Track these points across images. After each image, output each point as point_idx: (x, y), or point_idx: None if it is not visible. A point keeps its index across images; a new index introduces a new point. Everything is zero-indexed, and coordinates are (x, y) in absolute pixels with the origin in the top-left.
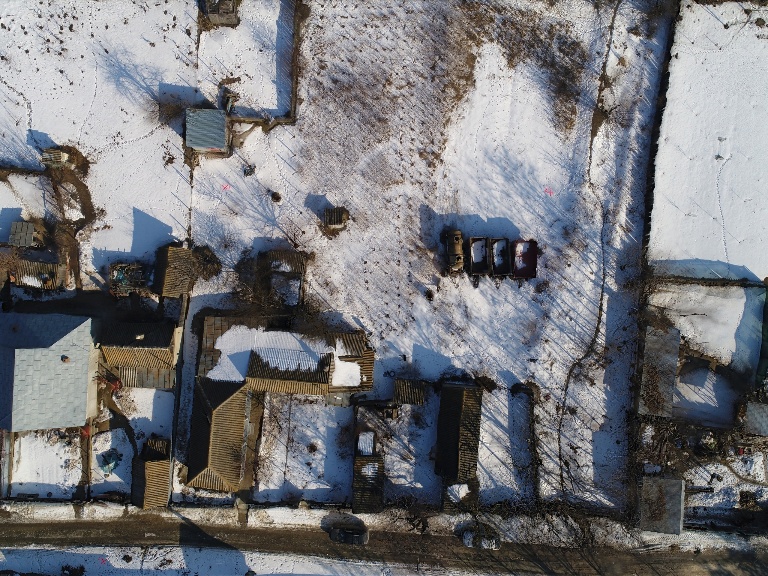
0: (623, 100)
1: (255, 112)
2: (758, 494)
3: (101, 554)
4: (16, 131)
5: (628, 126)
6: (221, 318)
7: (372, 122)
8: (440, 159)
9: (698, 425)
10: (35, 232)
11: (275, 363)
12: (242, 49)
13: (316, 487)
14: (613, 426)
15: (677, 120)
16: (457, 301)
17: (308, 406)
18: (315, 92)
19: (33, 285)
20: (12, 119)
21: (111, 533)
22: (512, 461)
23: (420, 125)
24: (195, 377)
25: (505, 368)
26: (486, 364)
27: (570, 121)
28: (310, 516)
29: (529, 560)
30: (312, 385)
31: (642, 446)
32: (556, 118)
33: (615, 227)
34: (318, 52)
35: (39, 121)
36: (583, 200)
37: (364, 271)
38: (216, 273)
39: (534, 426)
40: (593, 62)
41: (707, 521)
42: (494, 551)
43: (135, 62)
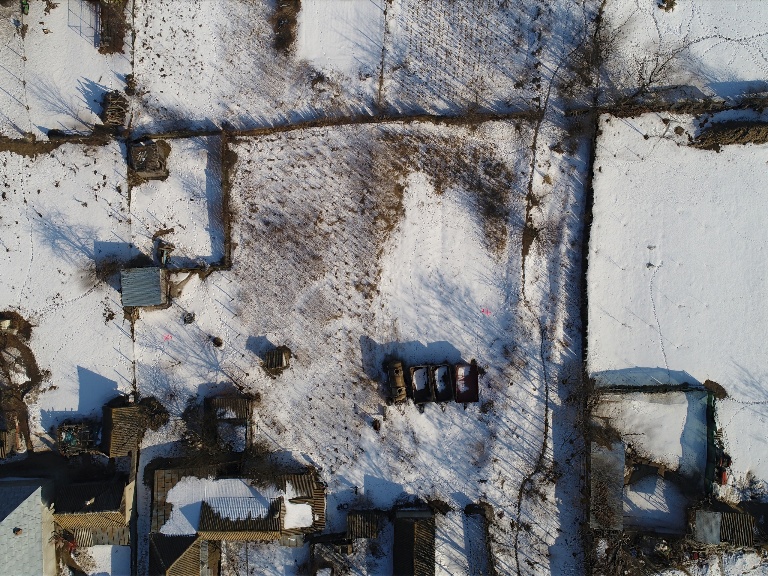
0: (551, 217)
1: (191, 261)
2: None
3: None
4: None
5: (558, 242)
6: (171, 471)
7: (306, 260)
8: (376, 290)
9: (650, 535)
10: None
11: (226, 513)
12: (173, 200)
13: None
14: (568, 539)
15: (606, 232)
16: (404, 428)
17: (264, 547)
18: (248, 235)
19: None
20: None
21: None
22: None
23: (354, 258)
24: (150, 528)
25: (457, 490)
26: (438, 488)
27: (501, 241)
28: None
29: None
30: (264, 533)
31: (597, 560)
32: (487, 239)
33: (553, 343)
34: (248, 196)
35: None
36: (520, 319)
37: (310, 408)
38: (164, 422)
39: (490, 545)
40: (519, 182)
41: None
42: None
43: (69, 223)
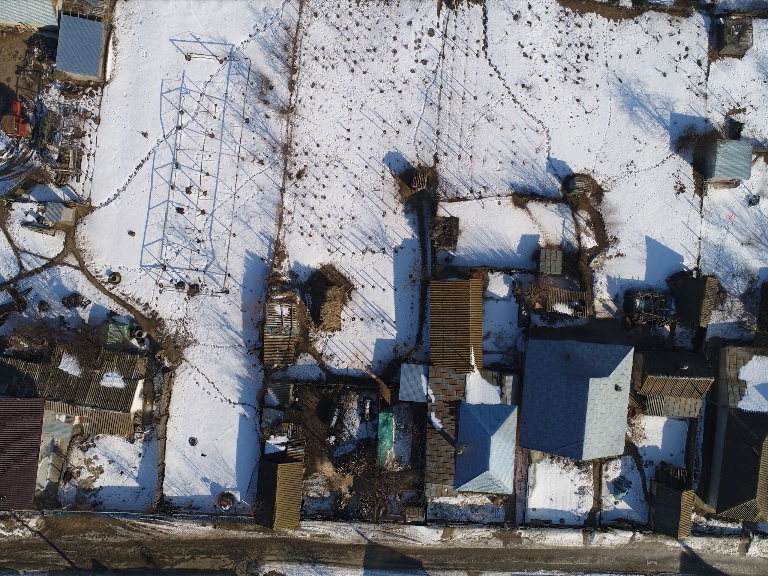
0: None
1: (759, 143)
2: None
3: None
4: (536, 158)
5: None
6: (742, 348)
7: None
8: None
9: None
10: None
11: None
12: (747, 80)
13: None
14: None
15: None
16: None
17: None
18: None
19: (565, 312)
20: (532, 147)
21: (615, 560)
22: None
23: None
24: (705, 406)
25: None
26: None
27: None
28: None
29: None
30: None
31: None
32: None
33: None
34: None
35: (557, 149)
36: None
37: None
38: (721, 302)
39: None
40: None
41: None
42: None
43: (647, 92)
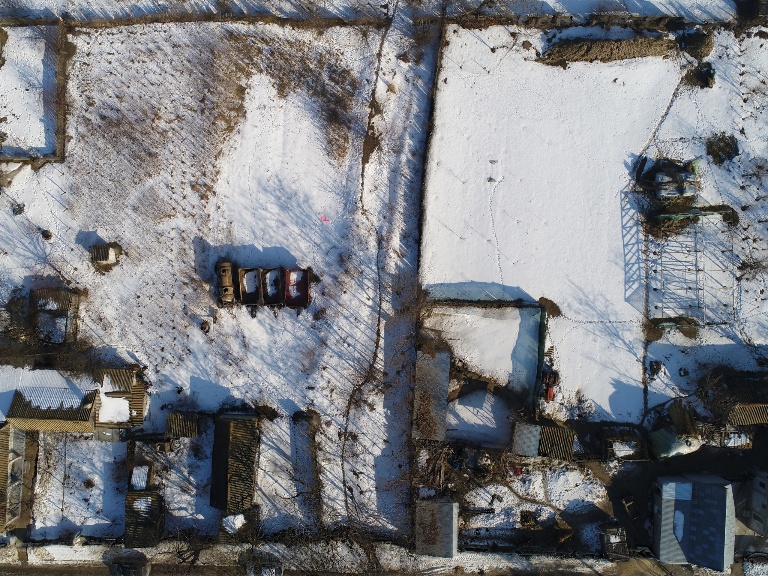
0: (394, 126)
1: (23, 151)
2: (537, 513)
3: None
4: None
5: (399, 152)
6: None
7: (142, 157)
8: (213, 191)
9: (472, 447)
10: None
11: (37, 402)
12: (8, 89)
13: (95, 523)
14: (394, 450)
15: (448, 144)
16: (234, 331)
17: (83, 442)
18: (84, 129)
19: None
20: None
21: None
22: (296, 489)
23: (191, 158)
24: None
25: (285, 396)
26: (266, 393)
27: (343, 149)
28: (91, 552)
29: None
30: (74, 423)
31: (417, 470)
32: (329, 146)
33: (389, 253)
34: (85, 89)
35: None
36: (356, 227)
37: (138, 305)
38: None
39: (316, 453)
40: (363, 90)
41: (489, 542)
42: None
43: None
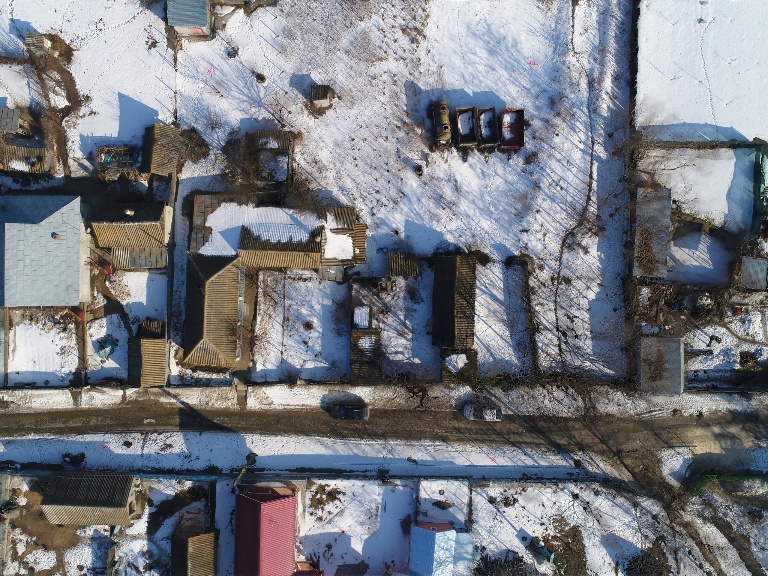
0: None
1: None
2: (758, 353)
3: (101, 441)
4: None
5: None
6: (211, 196)
7: (353, 0)
8: (423, 35)
9: (694, 285)
10: (21, 120)
11: (266, 236)
12: None
13: (314, 366)
14: (609, 294)
15: None
16: (447, 176)
17: (302, 284)
18: None
19: (21, 169)
20: None
21: (110, 420)
22: (509, 334)
23: (401, 2)
24: (187, 259)
25: (498, 241)
26: (479, 238)
27: None
28: (309, 395)
29: (531, 432)
30: (304, 255)
31: (639, 309)
32: None
33: (601, 94)
34: None
35: (21, 10)
36: (568, 69)
37: (352, 148)
38: (204, 156)
39: (530, 298)
40: None
41: (708, 384)
42: (496, 424)
43: None
